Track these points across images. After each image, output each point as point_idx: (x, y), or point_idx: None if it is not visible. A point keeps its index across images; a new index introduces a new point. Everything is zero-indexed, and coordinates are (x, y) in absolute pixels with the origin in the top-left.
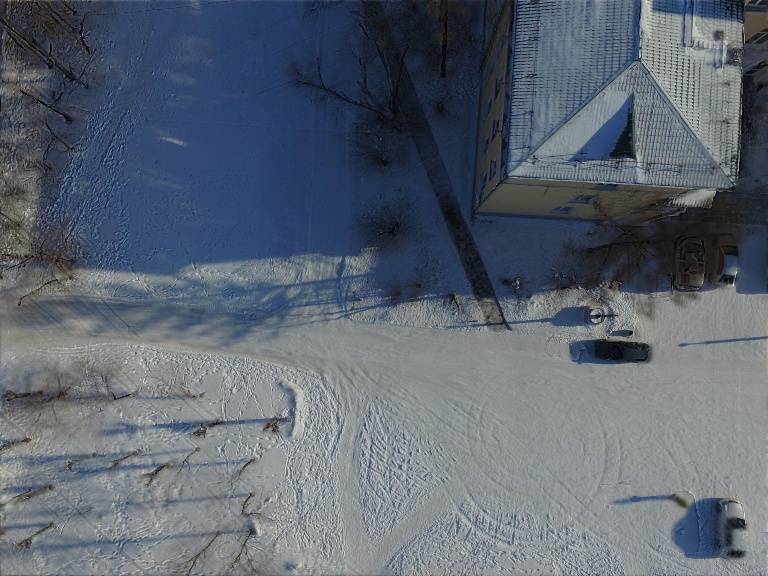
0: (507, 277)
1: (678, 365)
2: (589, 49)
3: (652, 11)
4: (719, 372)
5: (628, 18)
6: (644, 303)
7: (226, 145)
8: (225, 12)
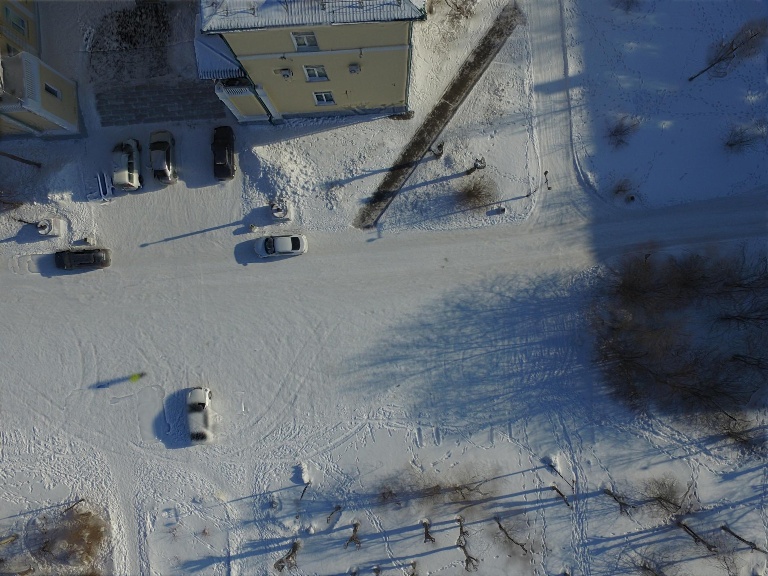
0: None
1: (142, 266)
2: None
3: None
4: (181, 267)
5: None
6: (101, 210)
7: None
8: None
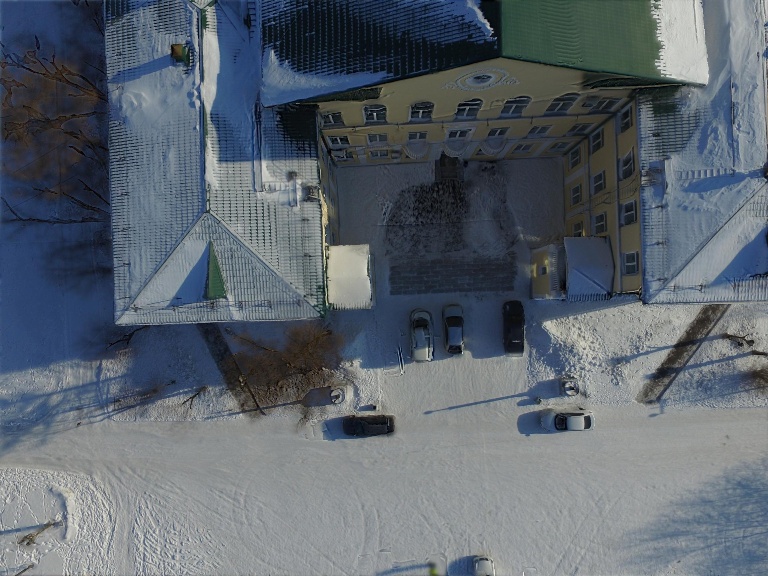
0: (255, 365)
1: (425, 432)
2: (169, 202)
3: (219, 163)
4: (464, 435)
5: (196, 172)
6: None
7: None
8: None
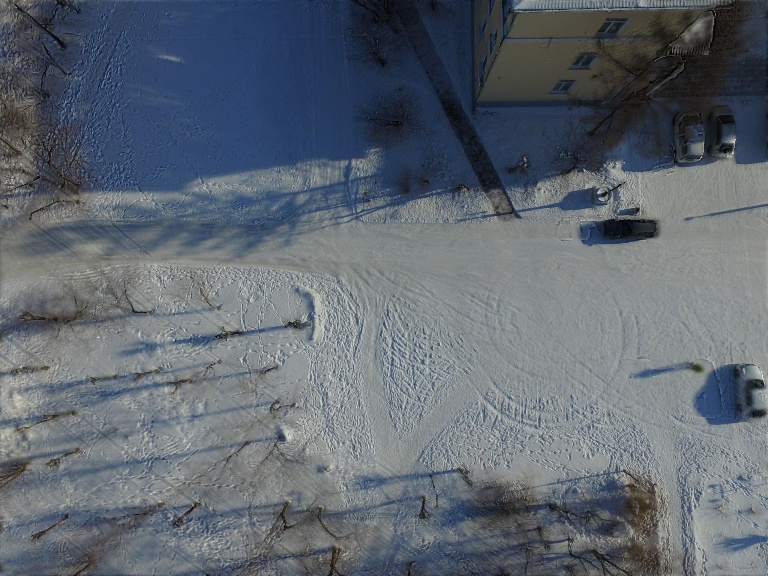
0: (513, 166)
1: (686, 239)
2: None
3: None
4: (726, 242)
5: None
6: (648, 181)
7: (224, 58)
8: None
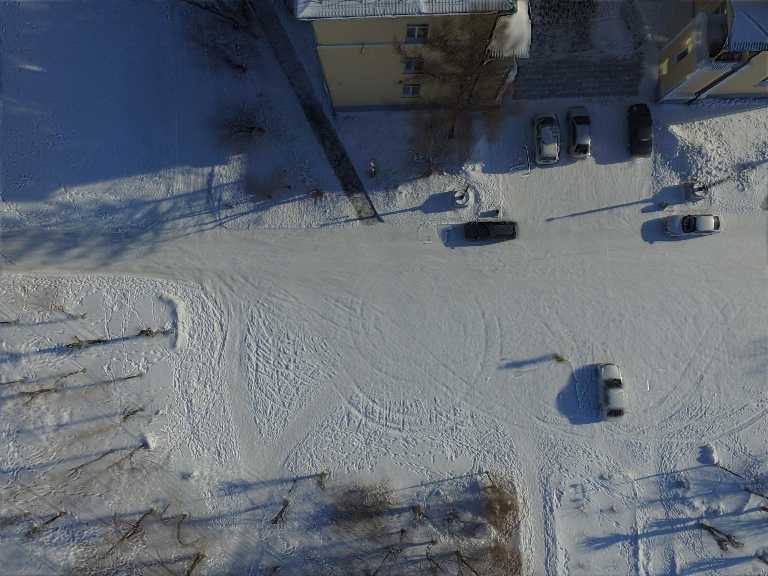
0: None
1: (547, 240)
2: None
3: None
4: (587, 242)
5: None
6: (509, 183)
7: (86, 67)
8: None
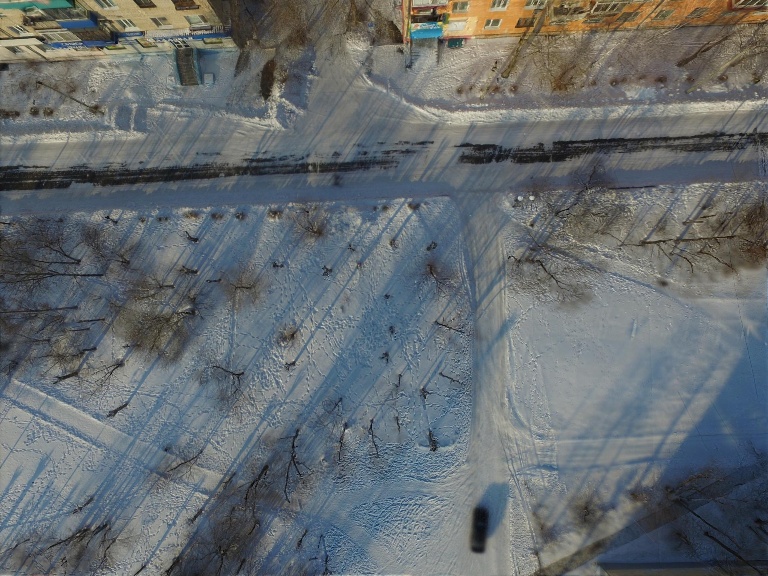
0: None
1: None
2: None
3: None
4: None
5: None
6: None
7: (635, 371)
8: (741, 358)
